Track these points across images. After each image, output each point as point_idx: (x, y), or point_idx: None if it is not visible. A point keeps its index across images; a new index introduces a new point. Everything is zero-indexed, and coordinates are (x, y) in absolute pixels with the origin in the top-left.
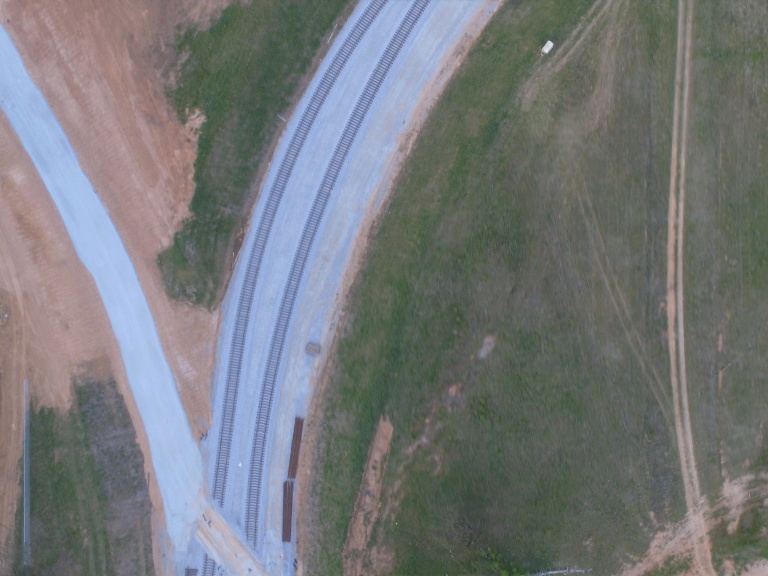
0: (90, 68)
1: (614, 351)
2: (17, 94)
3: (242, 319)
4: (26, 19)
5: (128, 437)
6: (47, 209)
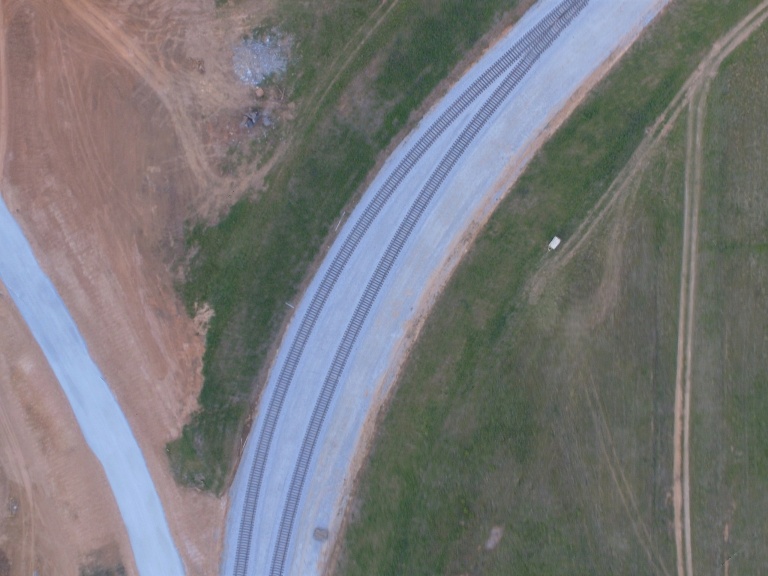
0: (99, 262)
1: (621, 541)
2: (26, 283)
3: (250, 505)
4: (35, 210)
5: None
6: (56, 397)
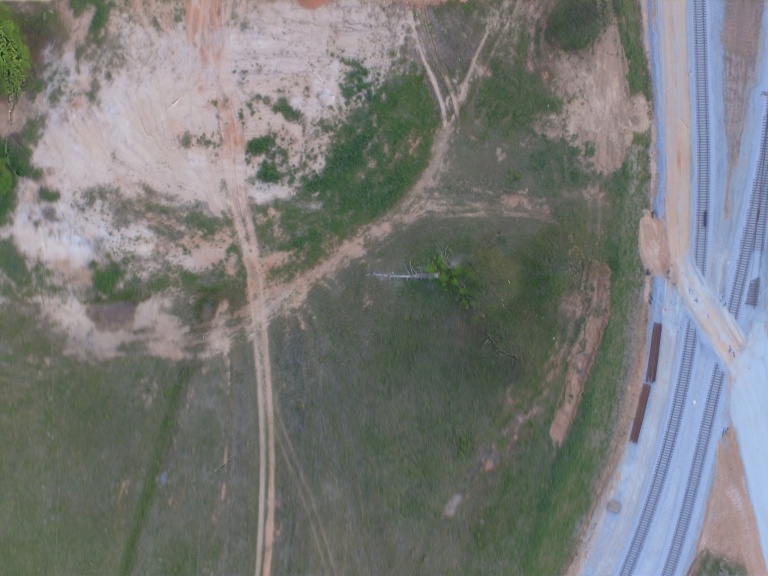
0: None
1: (330, 492)
2: None
3: (679, 541)
4: None
5: None
6: None
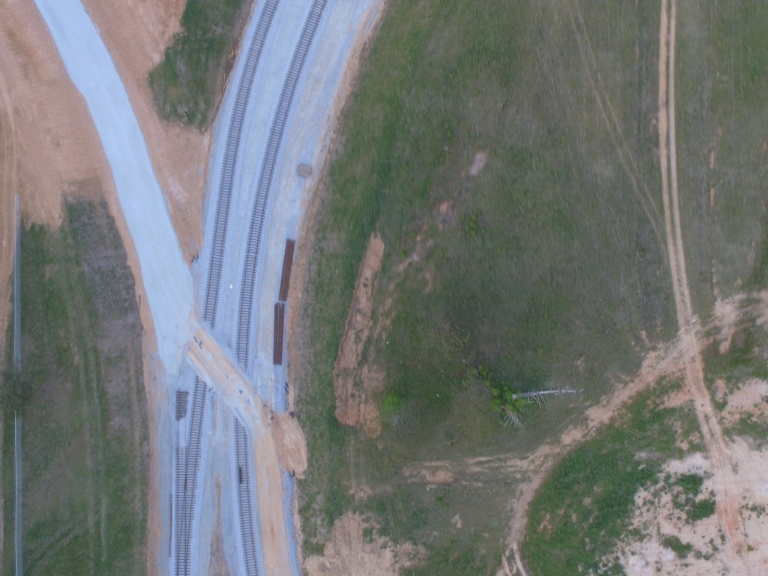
0: None
1: (605, 168)
2: None
3: (233, 140)
4: None
5: (119, 258)
6: (38, 29)
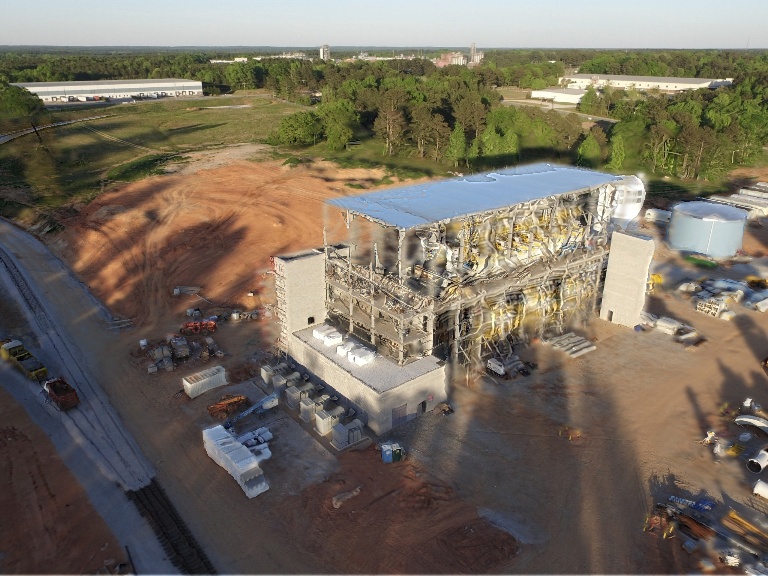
0: None
1: None
2: None
3: None
4: None
5: None
6: None
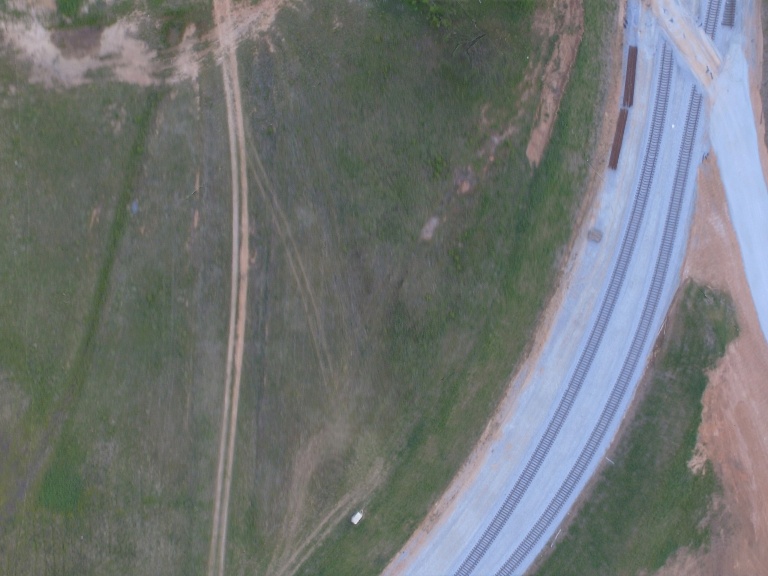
0: None
1: (304, 217)
2: None
3: (662, 269)
4: None
5: None
6: None
